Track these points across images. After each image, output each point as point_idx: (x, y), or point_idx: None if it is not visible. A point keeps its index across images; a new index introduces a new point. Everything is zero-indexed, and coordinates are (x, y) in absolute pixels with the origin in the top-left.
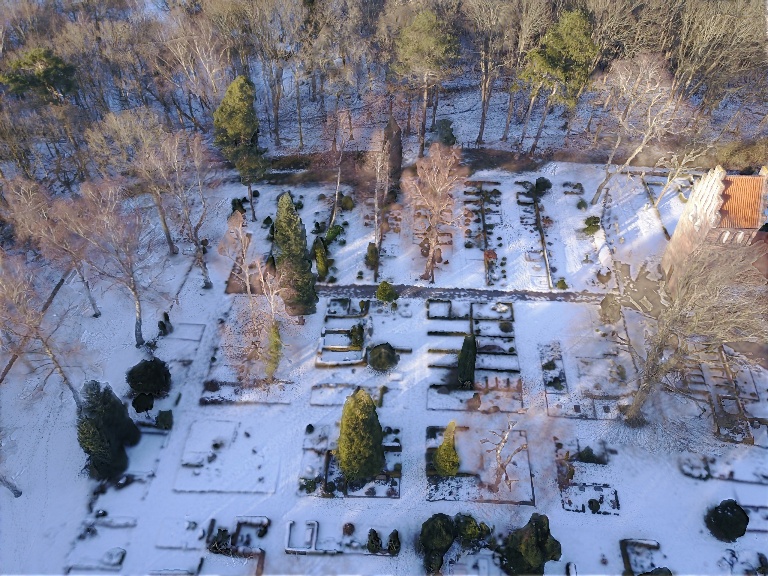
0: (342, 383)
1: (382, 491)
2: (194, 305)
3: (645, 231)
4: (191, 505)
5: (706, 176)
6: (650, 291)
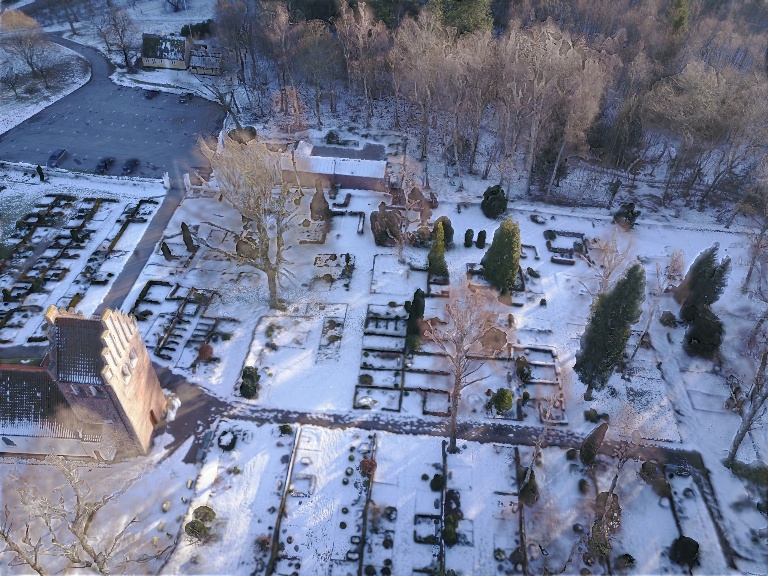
0: (526, 331)
1: (479, 267)
2: (725, 436)
3: (118, 527)
4: (611, 277)
5: (108, 347)
6: (183, 420)
